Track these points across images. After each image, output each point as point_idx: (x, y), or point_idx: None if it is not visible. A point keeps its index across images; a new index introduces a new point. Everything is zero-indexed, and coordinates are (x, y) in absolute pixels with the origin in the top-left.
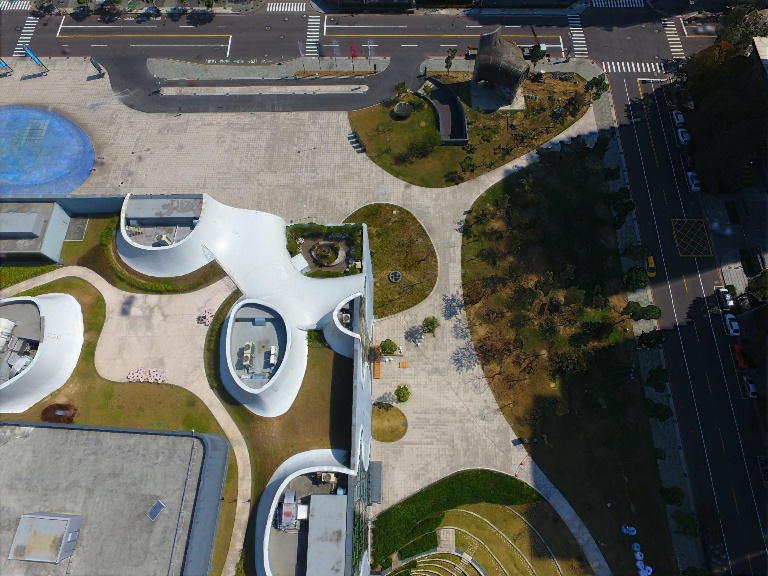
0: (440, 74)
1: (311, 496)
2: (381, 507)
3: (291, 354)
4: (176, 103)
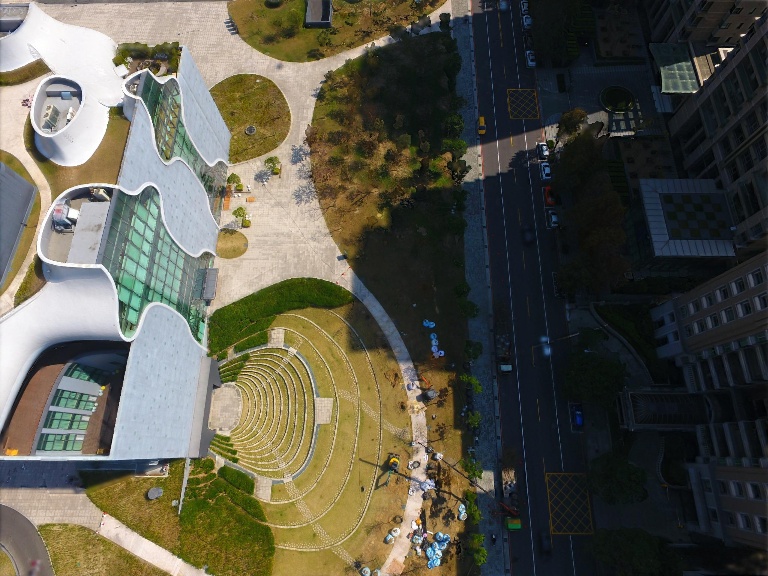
0: None
1: (82, 203)
2: (217, 307)
3: (85, 114)
4: None
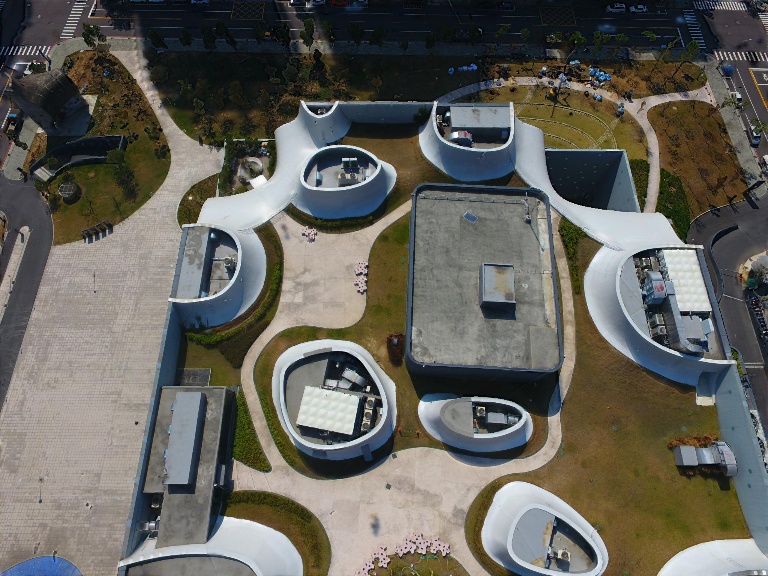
0: (29, 161)
1: (452, 127)
2: None
3: None
4: None
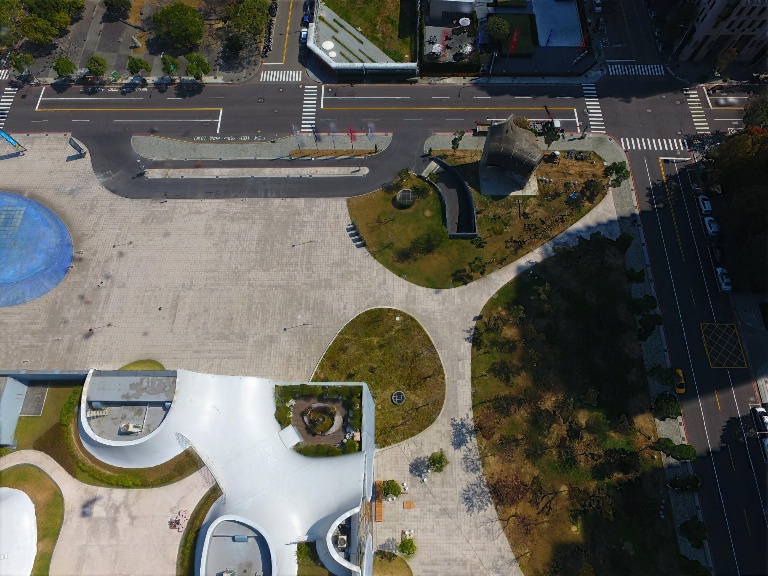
0: (446, 153)
1: None
2: None
3: None
4: (162, 187)
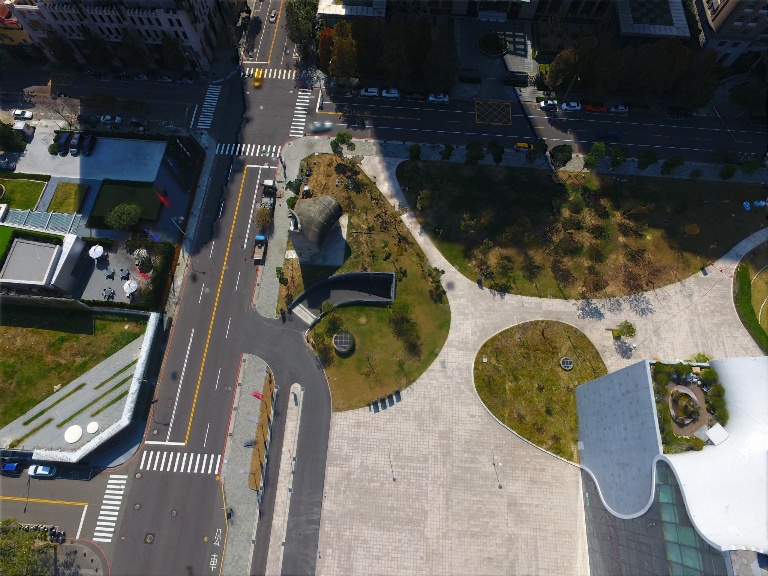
0: (285, 295)
1: None
2: None
3: None
4: None
